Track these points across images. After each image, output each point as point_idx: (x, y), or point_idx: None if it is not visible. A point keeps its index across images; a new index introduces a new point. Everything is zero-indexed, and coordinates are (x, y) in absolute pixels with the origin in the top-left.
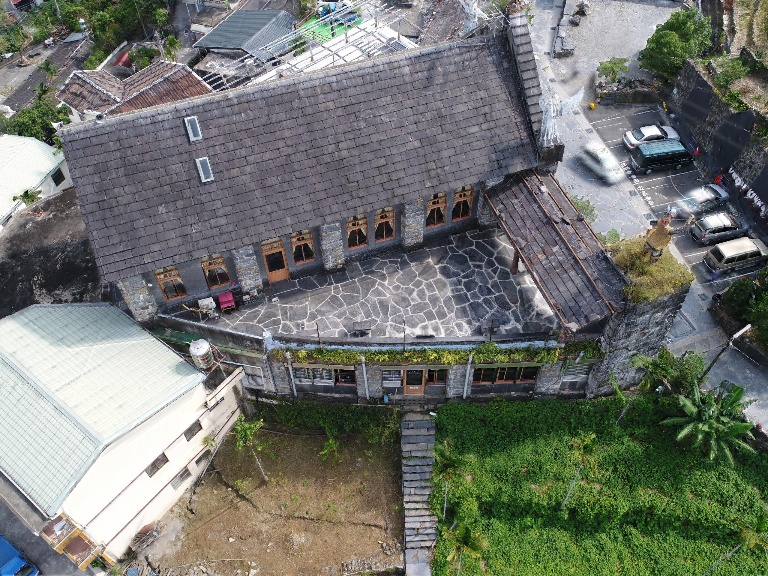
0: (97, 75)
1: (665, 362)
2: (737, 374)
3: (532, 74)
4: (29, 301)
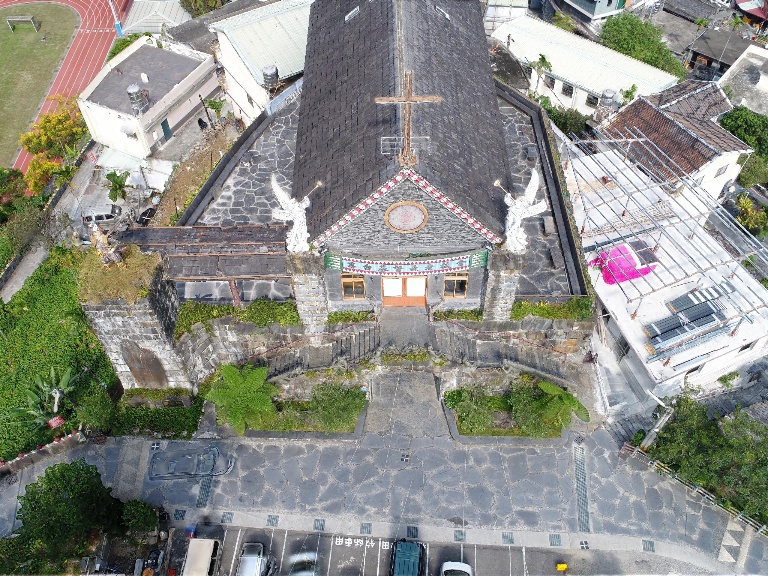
0: (717, 100)
1: (131, 418)
2: None
3: (349, 204)
4: None
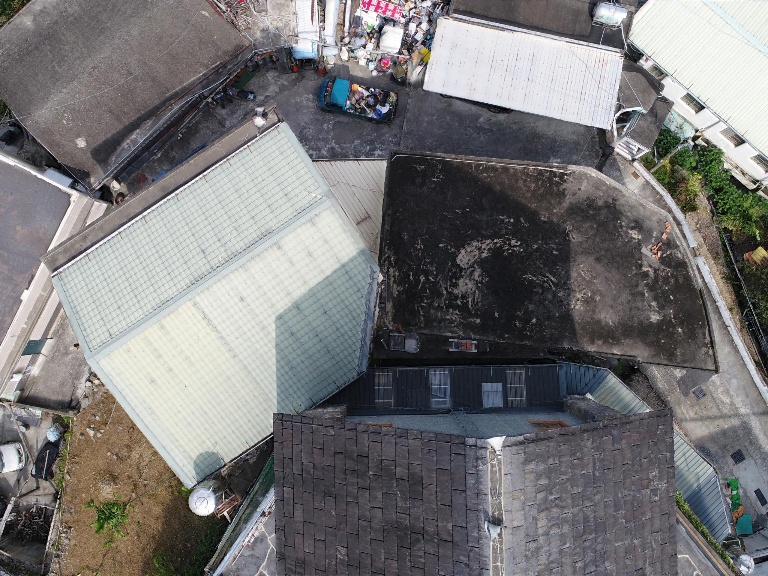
0: None
1: None
2: None
3: None
4: (472, 232)
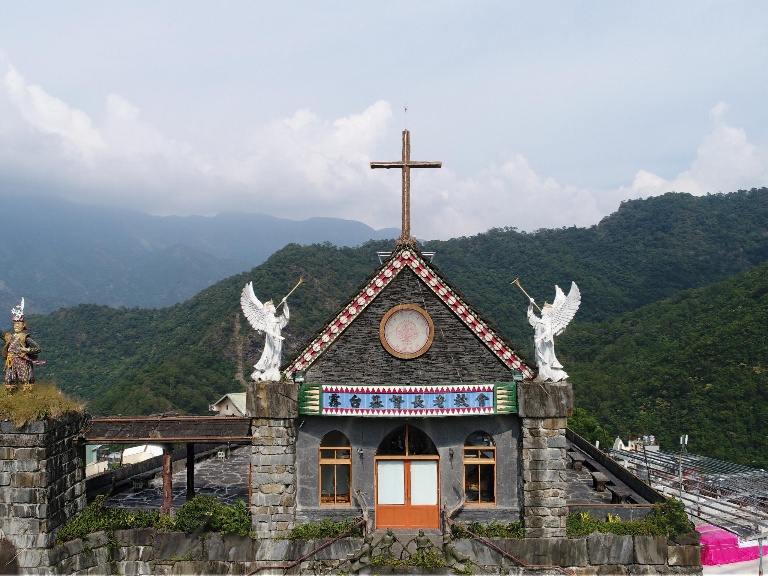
0: None
1: None
2: None
3: None
4: None
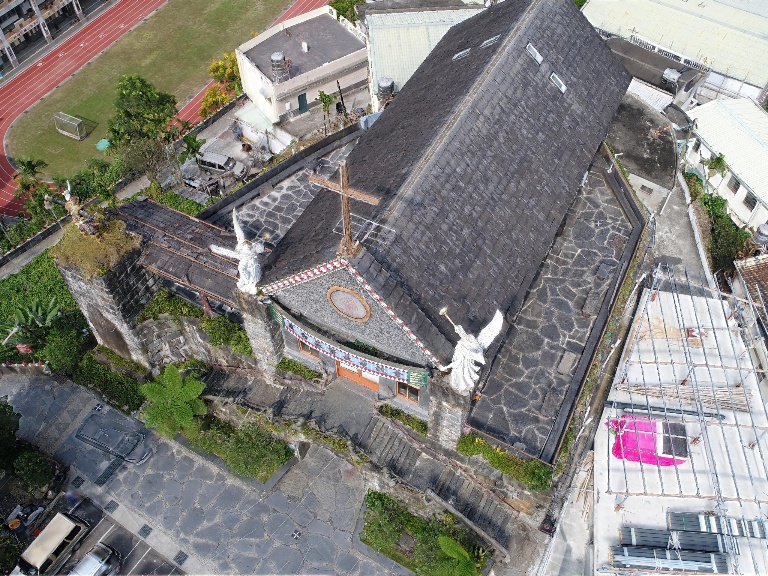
0: None
1: (93, 372)
2: (24, 416)
3: (295, 267)
4: None
